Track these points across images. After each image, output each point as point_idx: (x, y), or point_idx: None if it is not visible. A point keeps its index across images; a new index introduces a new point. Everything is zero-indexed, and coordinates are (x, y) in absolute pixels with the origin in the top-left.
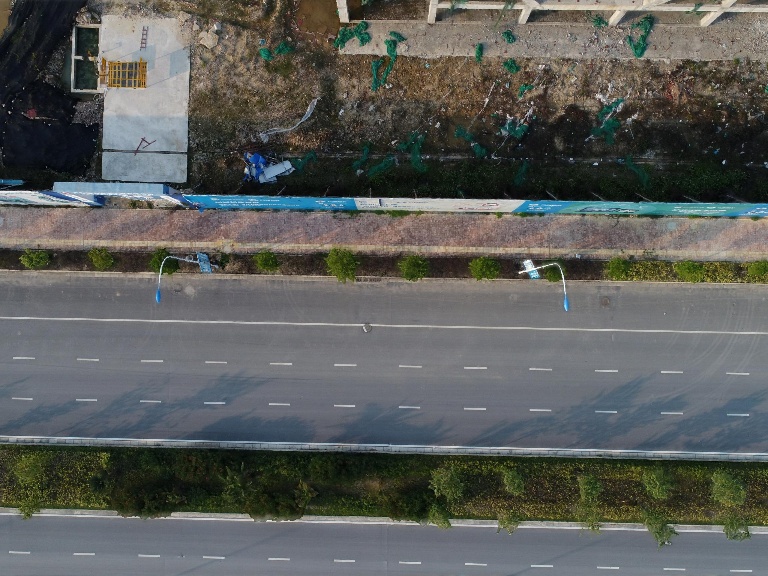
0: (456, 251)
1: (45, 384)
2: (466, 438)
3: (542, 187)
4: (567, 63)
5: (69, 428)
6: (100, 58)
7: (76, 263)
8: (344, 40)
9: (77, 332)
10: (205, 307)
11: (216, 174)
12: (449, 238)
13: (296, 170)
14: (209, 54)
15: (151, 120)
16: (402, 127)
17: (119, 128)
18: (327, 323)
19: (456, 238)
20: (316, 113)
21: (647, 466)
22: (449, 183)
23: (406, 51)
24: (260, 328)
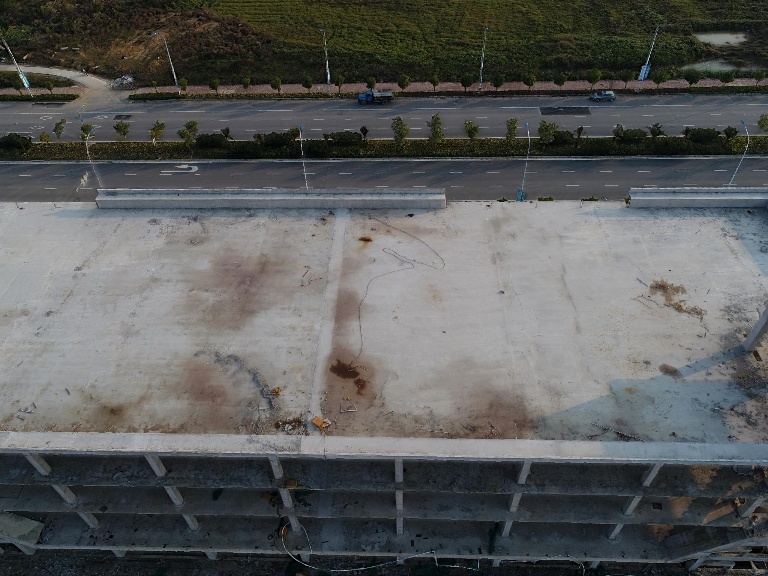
0: None
1: None
2: (533, 163)
3: None
4: None
5: (762, 161)
6: None
7: None
8: None
9: None
10: None
11: None
12: None
13: None
14: None
15: None
16: None
17: None
18: None
19: None
20: None
21: (433, 155)
22: None
23: None
24: None
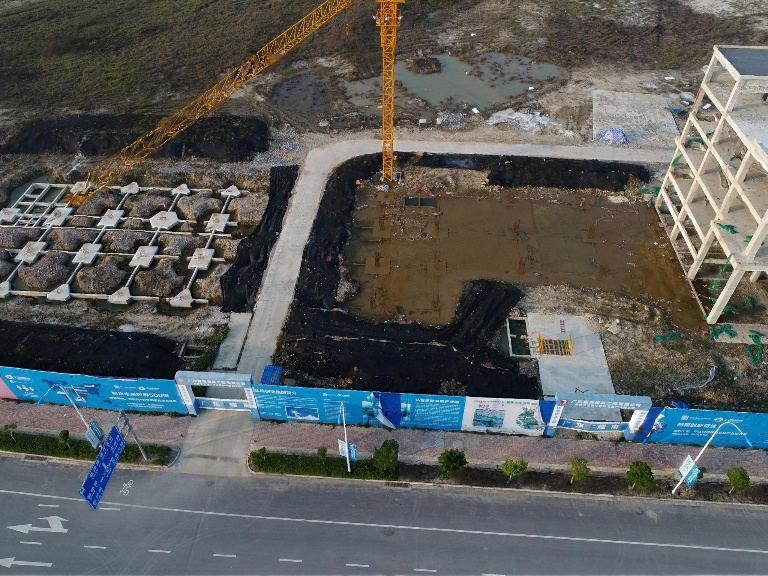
0: None
1: None
2: None
3: None
4: None
5: None
6: (530, 336)
7: (537, 482)
8: (716, 334)
9: (546, 550)
10: (672, 531)
11: None
12: None
13: None
14: (615, 337)
15: (580, 376)
16: None
17: (555, 381)
18: None
19: None
20: (717, 377)
21: None
22: None
23: None
24: (737, 555)
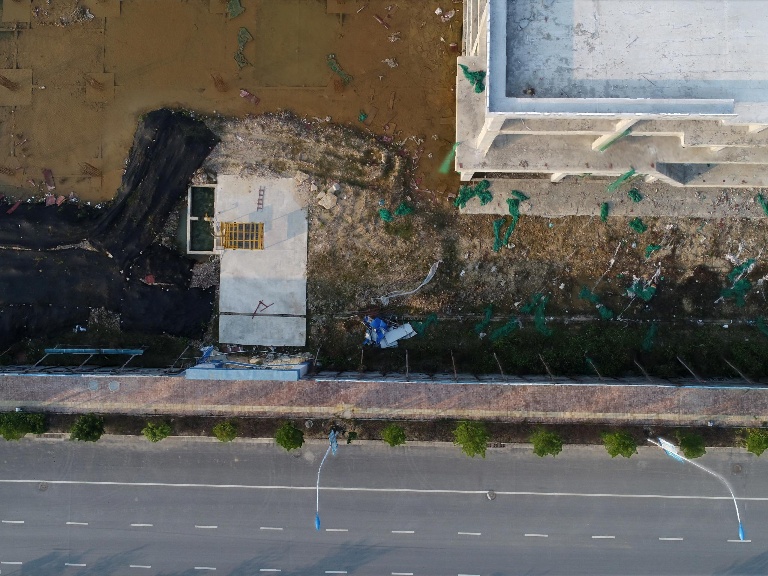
0: (582, 417)
1: (163, 552)
2: None
3: (672, 353)
4: (695, 222)
5: None
6: (216, 219)
7: (194, 429)
8: (465, 199)
9: (195, 498)
10: (325, 473)
11: (335, 337)
12: (575, 404)
13: (417, 334)
14: (327, 214)
15: (269, 282)
16: (525, 288)
17: (236, 291)
18: (450, 490)
19: (582, 404)
20: (438, 275)
21: None
22: (576, 348)
23: (529, 210)
24: (381, 495)
